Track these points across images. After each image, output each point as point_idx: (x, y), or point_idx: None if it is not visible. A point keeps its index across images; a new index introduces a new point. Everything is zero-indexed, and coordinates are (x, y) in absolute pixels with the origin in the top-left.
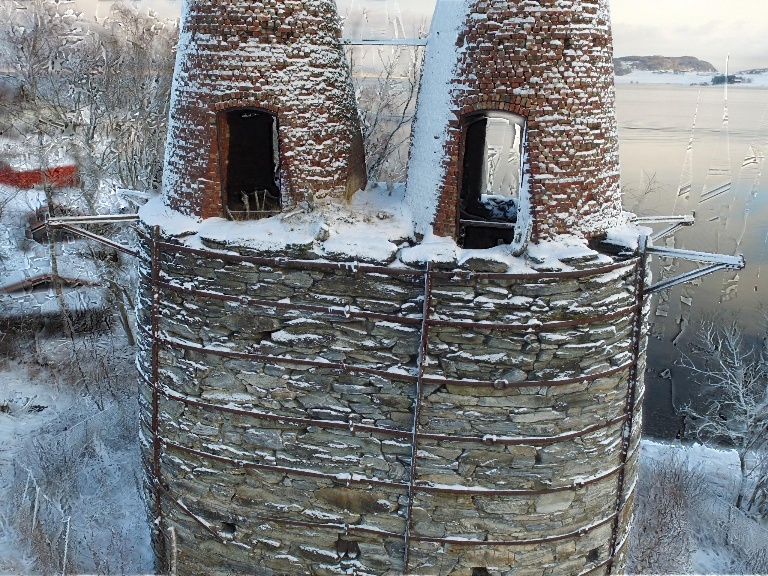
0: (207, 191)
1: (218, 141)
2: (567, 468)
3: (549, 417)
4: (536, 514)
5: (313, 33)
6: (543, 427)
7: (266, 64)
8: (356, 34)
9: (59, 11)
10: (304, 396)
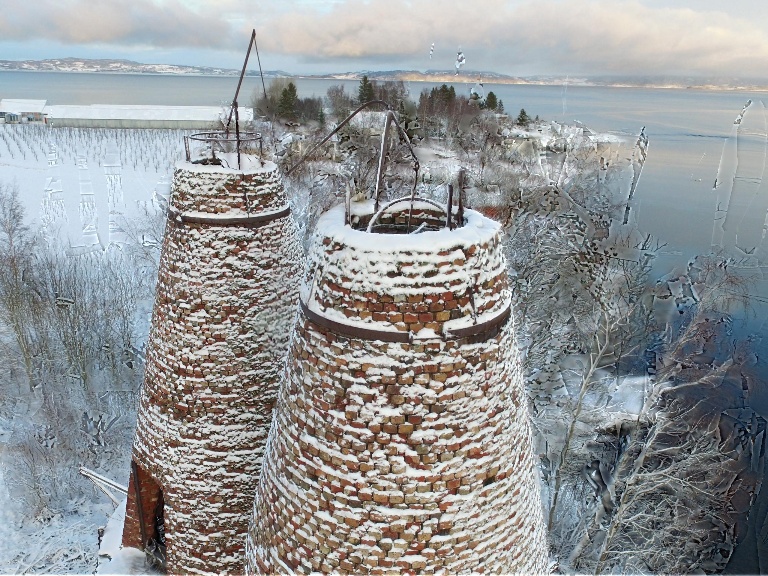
0: (127, 524)
1: (136, 485)
2: None
3: None
4: None
5: (219, 412)
6: None
7: (161, 437)
8: (728, 172)
9: (409, 134)
10: None
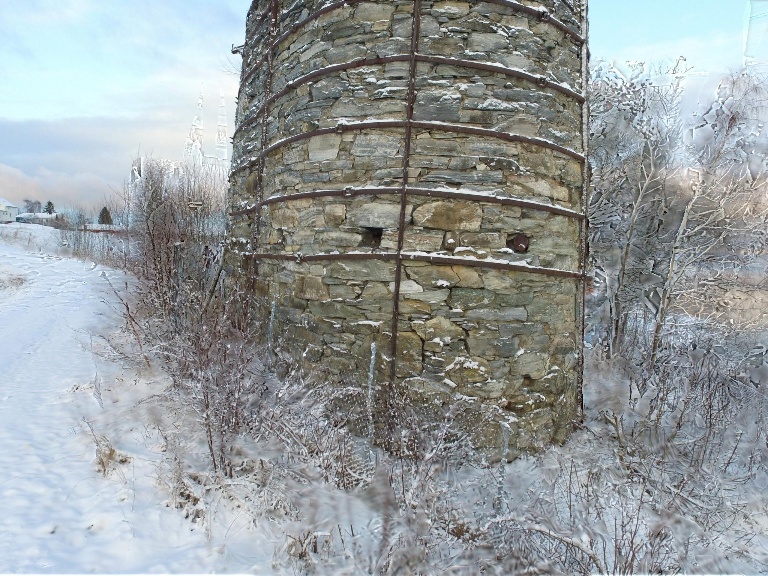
0: None
1: None
2: (333, 107)
3: (319, 49)
4: (309, 161)
5: None
6: (315, 61)
7: None
8: None
9: None
10: (250, 102)
